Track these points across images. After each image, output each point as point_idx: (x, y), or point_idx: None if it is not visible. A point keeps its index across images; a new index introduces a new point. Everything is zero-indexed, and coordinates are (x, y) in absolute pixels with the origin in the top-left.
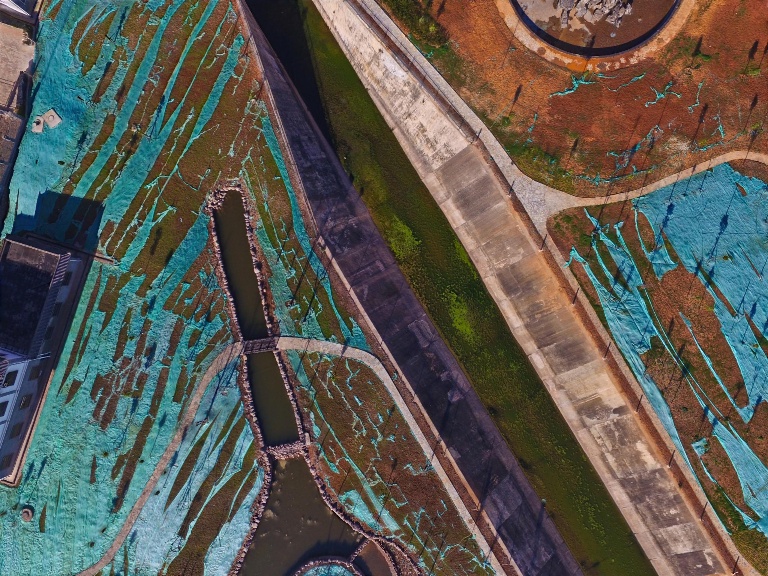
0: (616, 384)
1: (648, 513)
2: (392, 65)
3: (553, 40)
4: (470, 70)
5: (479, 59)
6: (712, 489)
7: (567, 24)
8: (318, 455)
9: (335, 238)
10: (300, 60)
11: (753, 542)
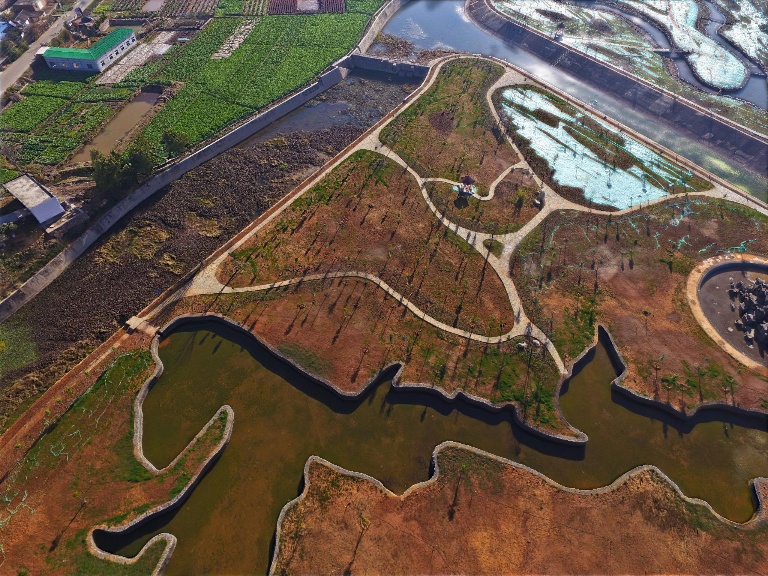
0: (634, 133)
1: None
2: None
3: None
4: None
5: None
6: (567, 105)
7: None
8: None
9: None
10: None
11: (541, 92)
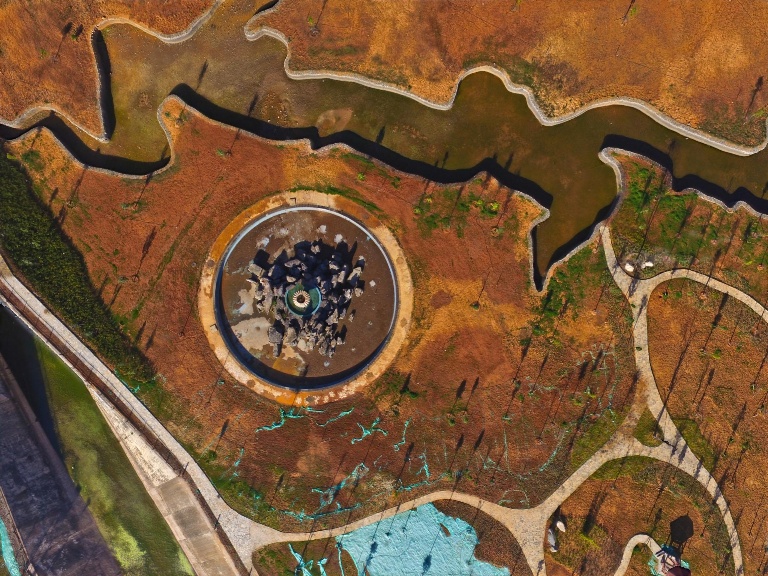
0: None
1: None
2: (100, 398)
3: (266, 368)
4: (177, 404)
5: (186, 393)
6: None
7: (280, 353)
8: None
9: (48, 562)
10: (31, 369)
11: None
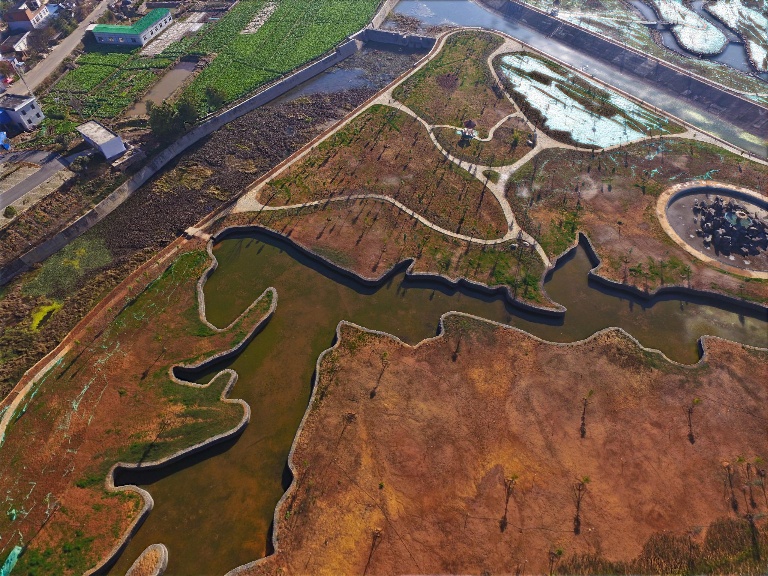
0: None
1: None
2: None
3: None
4: None
5: None
6: None
7: None
8: (741, 73)
9: None
10: None
11: (537, 57)
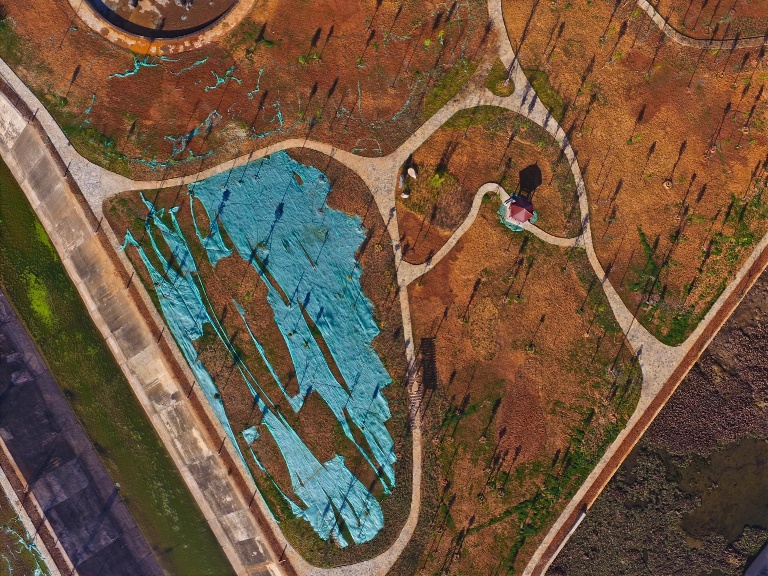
0: (169, 370)
1: (212, 500)
2: None
3: (122, 21)
4: (27, 48)
5: (37, 37)
6: (261, 477)
7: (136, 5)
8: None
9: None
10: None
11: (300, 531)
